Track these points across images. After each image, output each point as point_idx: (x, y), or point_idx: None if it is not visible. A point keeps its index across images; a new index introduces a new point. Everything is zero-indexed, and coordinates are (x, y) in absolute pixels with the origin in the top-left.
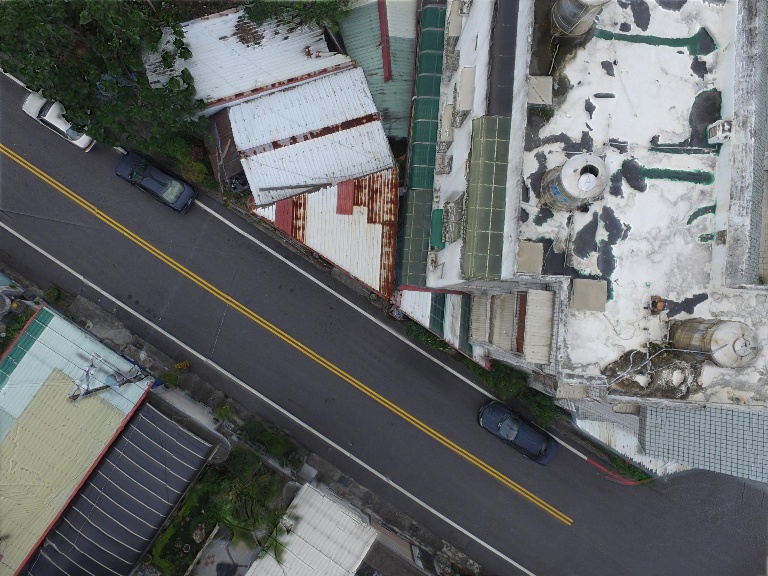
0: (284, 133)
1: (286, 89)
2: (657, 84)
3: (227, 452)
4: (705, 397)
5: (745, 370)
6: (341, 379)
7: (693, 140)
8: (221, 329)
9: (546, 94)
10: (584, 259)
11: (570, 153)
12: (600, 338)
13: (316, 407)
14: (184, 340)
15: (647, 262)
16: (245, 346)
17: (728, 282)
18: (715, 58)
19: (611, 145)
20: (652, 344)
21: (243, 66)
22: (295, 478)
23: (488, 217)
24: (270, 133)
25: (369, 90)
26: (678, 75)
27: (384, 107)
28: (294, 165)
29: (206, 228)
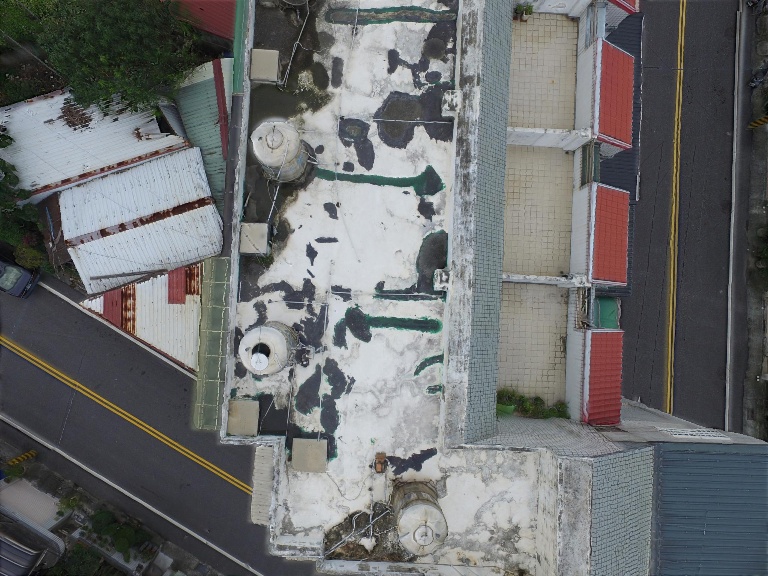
0: (114, 220)
1: (119, 171)
2: (382, 227)
3: (55, 557)
4: (434, 559)
5: (475, 529)
6: (196, 464)
7: (420, 285)
8: (69, 416)
9: (260, 242)
10: (307, 415)
11: (290, 303)
12: (324, 499)
13: (170, 493)
14: (29, 429)
15: (372, 417)
16: (94, 433)
17: (447, 442)
18: (443, 198)
19: (333, 293)
20: (379, 504)
21: (70, 150)
22: (150, 568)
23: (216, 366)
24: (99, 220)
25: (204, 171)
26: (404, 217)
27: (223, 187)
28: (125, 252)
29: (52, 311)
